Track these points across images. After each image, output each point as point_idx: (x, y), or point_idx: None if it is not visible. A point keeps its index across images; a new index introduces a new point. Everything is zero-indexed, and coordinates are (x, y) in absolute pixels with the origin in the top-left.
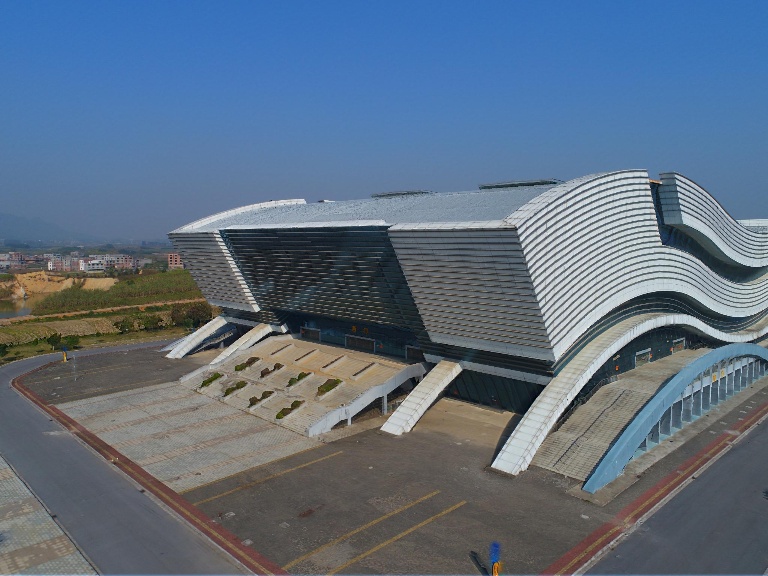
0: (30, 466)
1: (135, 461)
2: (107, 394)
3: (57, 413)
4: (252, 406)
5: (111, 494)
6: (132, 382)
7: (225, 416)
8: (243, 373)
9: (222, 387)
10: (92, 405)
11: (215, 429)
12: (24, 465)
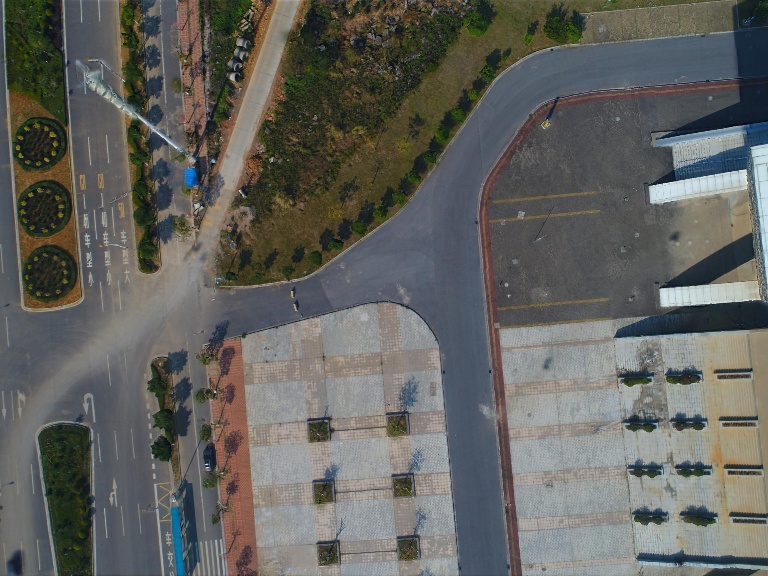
0: (461, 478)
1: (518, 519)
2: (546, 325)
3: (497, 359)
4: (633, 475)
5: (492, 560)
6: (579, 293)
7: (607, 469)
8: (671, 385)
9: (638, 398)
10: (526, 356)
11: (587, 495)
12: (458, 472)
